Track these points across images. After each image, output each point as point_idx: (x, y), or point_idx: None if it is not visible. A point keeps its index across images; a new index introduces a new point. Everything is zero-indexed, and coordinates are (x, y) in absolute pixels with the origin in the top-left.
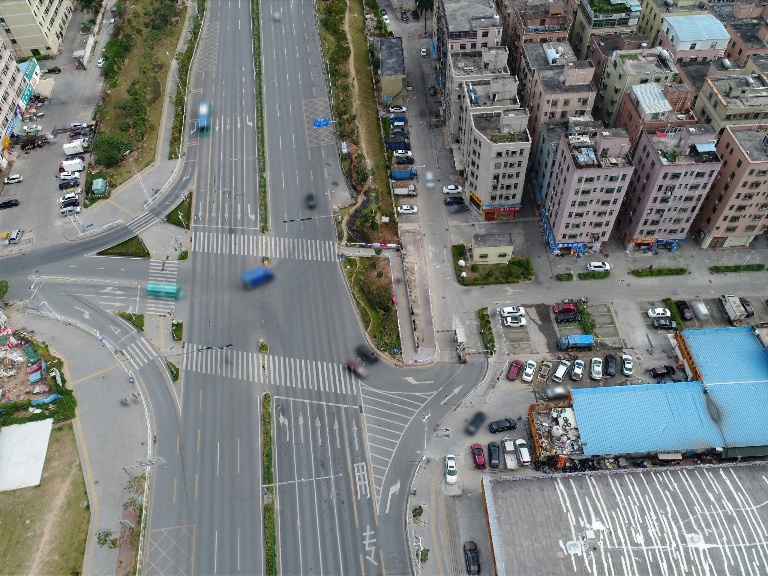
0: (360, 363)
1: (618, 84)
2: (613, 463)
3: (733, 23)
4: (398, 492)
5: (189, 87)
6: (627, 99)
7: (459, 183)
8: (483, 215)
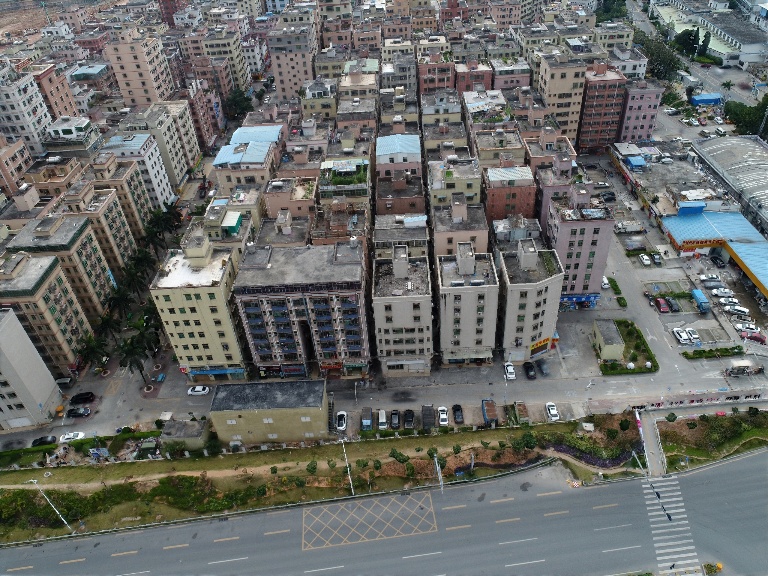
0: None
1: (470, 193)
2: None
3: None
4: None
5: None
6: (497, 190)
7: (495, 366)
8: None
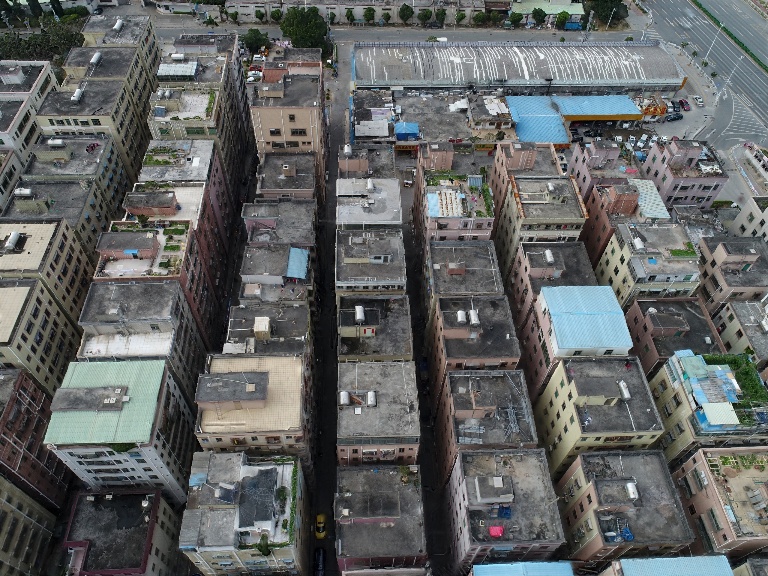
0: None
1: None
2: None
3: (500, 385)
4: (723, 96)
5: None
6: None
7: None
8: None
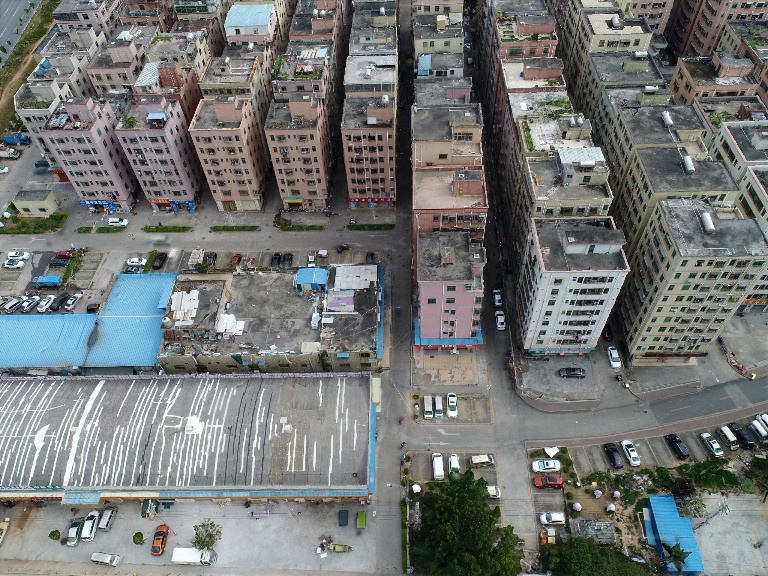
0: None
1: None
2: None
3: None
4: None
5: None
6: None
7: None
8: (58, 176)
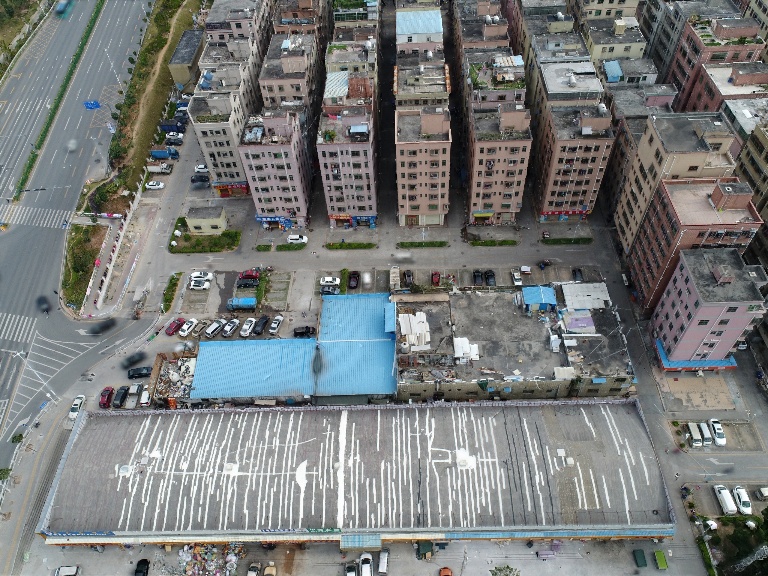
0: (44, 316)
1: None
2: (221, 407)
3: None
4: None
5: (10, 72)
6: None
7: None
8: (218, 192)
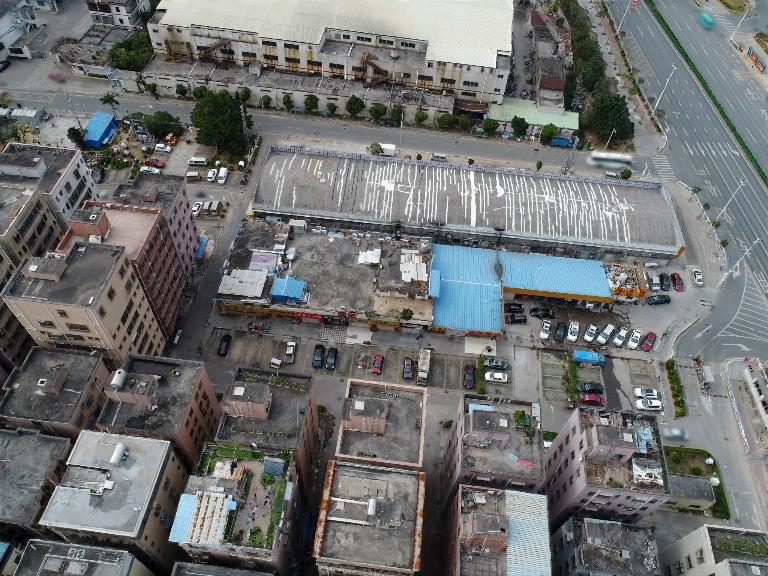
0: None
1: None
2: None
3: None
4: None
5: None
6: None
7: None
8: None
